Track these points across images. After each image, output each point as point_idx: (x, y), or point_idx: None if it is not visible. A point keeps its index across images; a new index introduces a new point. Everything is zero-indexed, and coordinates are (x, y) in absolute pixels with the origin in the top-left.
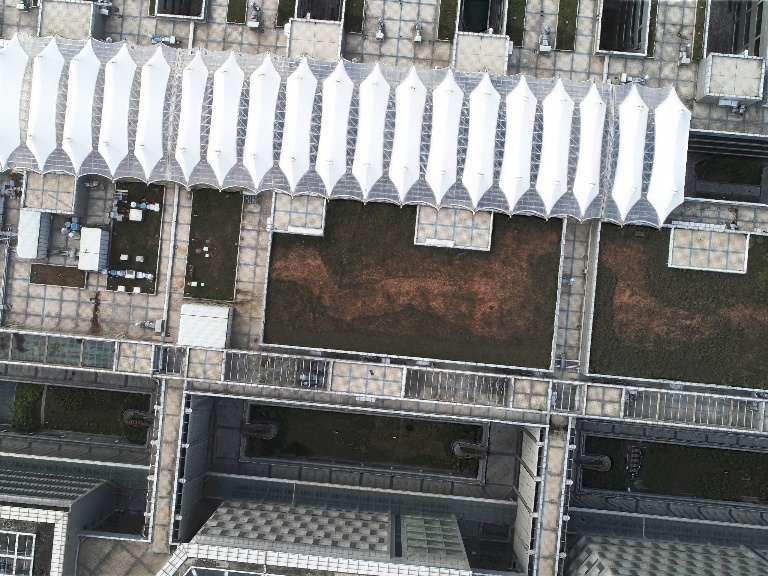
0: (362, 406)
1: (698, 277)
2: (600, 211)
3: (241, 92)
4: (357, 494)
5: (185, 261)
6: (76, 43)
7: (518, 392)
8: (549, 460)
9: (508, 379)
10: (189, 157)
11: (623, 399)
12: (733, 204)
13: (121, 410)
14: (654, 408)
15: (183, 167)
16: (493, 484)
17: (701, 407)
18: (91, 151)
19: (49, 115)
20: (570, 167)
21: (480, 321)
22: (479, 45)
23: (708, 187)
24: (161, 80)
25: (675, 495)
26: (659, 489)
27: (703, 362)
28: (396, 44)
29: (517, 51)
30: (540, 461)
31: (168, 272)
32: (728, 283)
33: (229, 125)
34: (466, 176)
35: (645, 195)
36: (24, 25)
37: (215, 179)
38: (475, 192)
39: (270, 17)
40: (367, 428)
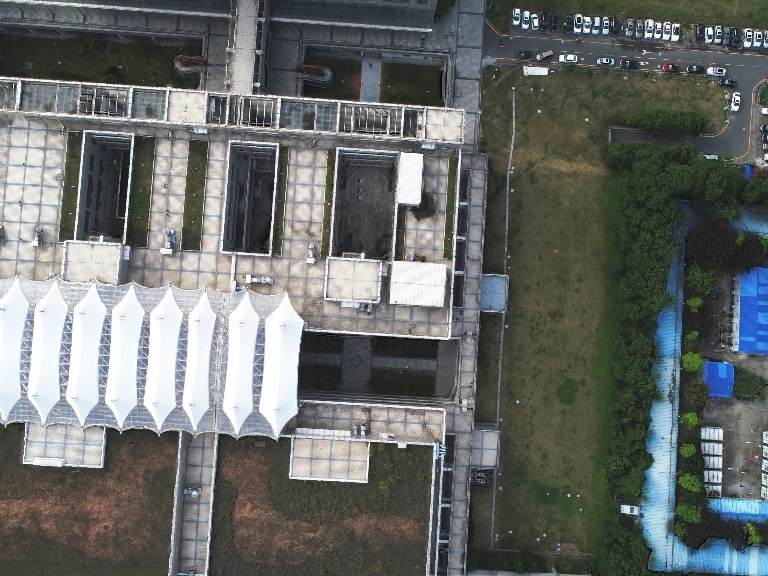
0: None
1: (320, 487)
2: (213, 425)
3: None
4: None
5: None
6: None
7: None
8: None
9: None
10: None
11: None
12: (363, 406)
13: None
14: None
15: None
16: None
17: None
18: None
19: None
20: (178, 381)
21: (94, 542)
22: (90, 253)
23: (384, 362)
24: None
25: None
26: None
27: None
28: (16, 247)
29: (142, 252)
30: None
31: None
32: (351, 492)
33: None
34: (68, 395)
35: (257, 408)
36: None
37: None
38: (77, 411)
39: None
40: None
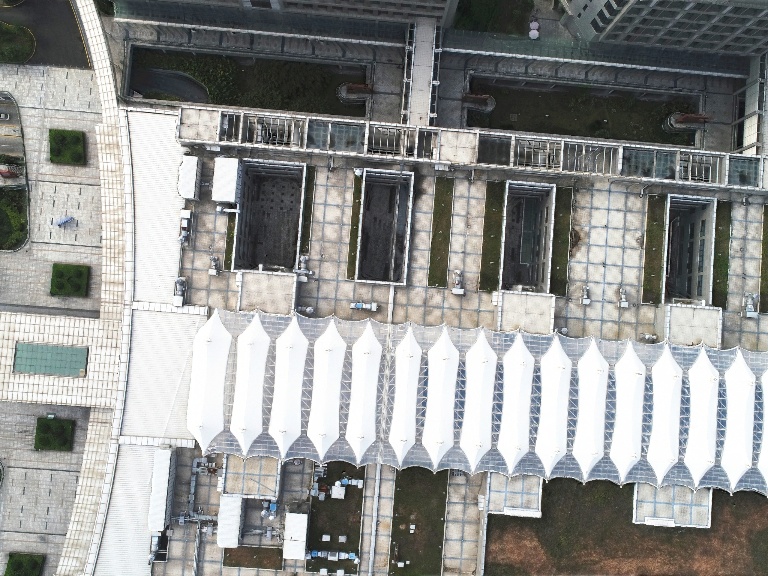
0: None
1: None
2: None
3: (457, 372)
4: None
5: (388, 537)
6: (281, 319)
7: None
8: None
9: None
10: (407, 444)
11: None
12: None
13: None
14: None
15: (398, 452)
16: None
17: None
18: (299, 435)
19: (256, 400)
20: None
21: None
22: (692, 317)
23: None
24: (375, 362)
25: None
26: None
27: None
28: (600, 307)
29: None
30: None
31: (371, 551)
32: None
33: (447, 409)
34: (689, 457)
35: None
36: (214, 289)
37: (429, 461)
38: (699, 474)
39: (472, 280)
40: None
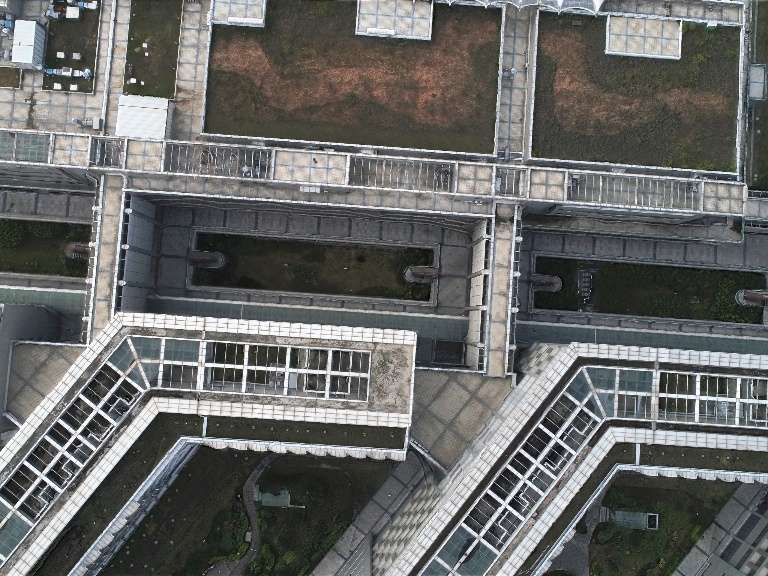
0: (307, 200)
1: (635, 63)
2: None
3: None
4: (306, 313)
5: (124, 61)
6: None
7: (462, 178)
8: (496, 252)
9: (452, 165)
10: None
11: (566, 182)
12: None
13: (63, 246)
14: (597, 191)
15: None
16: (445, 307)
17: (643, 190)
18: None
19: None
20: None
21: (423, 109)
22: None
23: None
24: None
25: (626, 314)
26: (610, 309)
27: (643, 146)
28: None
29: None
30: (487, 254)
31: (106, 71)
32: (664, 69)
33: None
34: None
35: None
36: None
37: None
38: None
39: None
40: (318, 261)
